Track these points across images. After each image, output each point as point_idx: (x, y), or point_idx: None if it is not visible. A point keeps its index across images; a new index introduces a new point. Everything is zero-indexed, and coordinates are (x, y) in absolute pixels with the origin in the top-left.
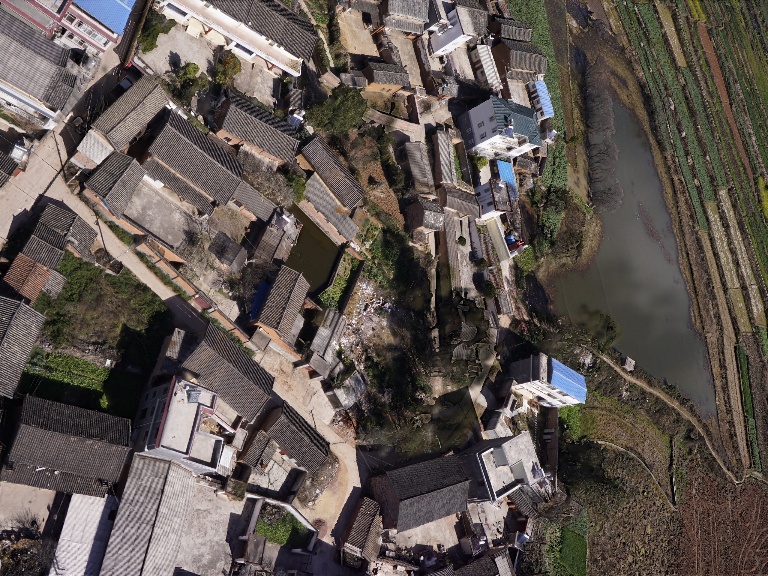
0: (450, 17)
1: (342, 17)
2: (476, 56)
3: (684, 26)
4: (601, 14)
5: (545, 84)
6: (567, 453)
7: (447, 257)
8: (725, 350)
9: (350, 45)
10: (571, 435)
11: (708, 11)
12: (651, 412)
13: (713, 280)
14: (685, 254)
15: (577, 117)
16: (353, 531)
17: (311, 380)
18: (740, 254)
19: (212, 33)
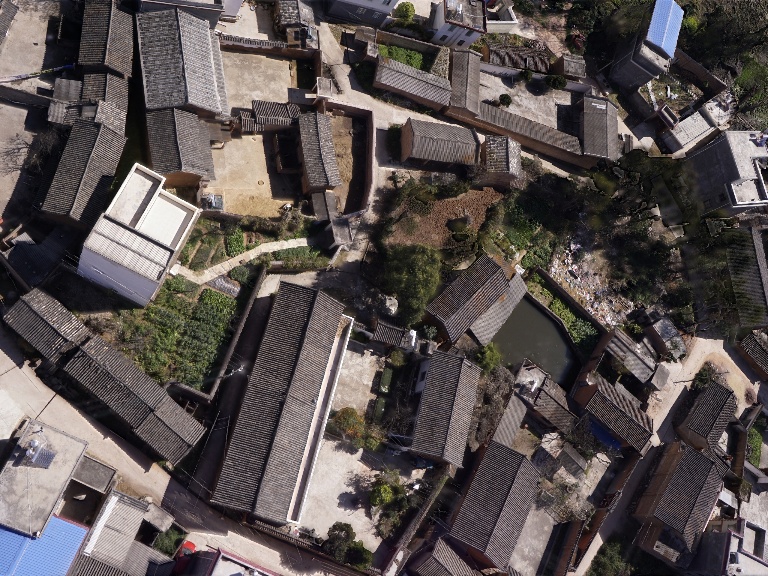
0: None
1: (214, 192)
2: None
3: None
4: None
5: None
6: None
7: (532, 140)
8: None
9: (258, 191)
10: None
11: None
12: None
13: None
14: None
15: None
16: (763, 368)
17: None
18: None
19: None
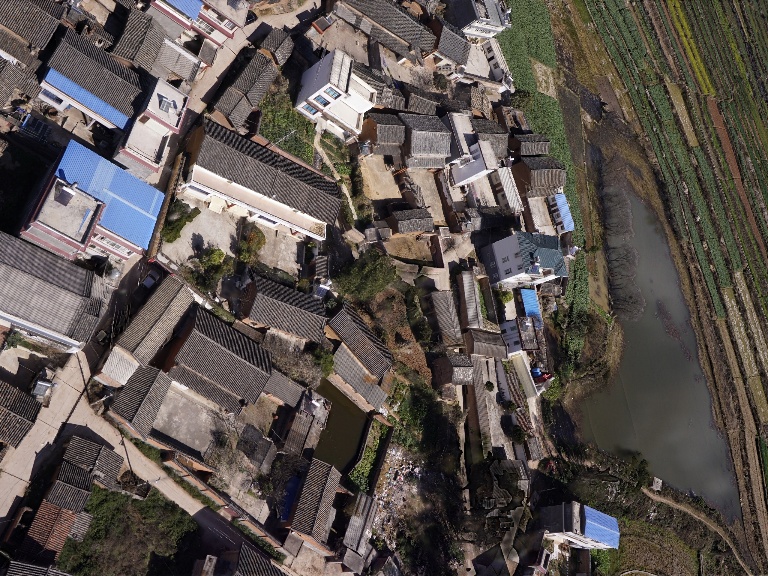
0: (472, 150)
1: (364, 162)
2: (496, 179)
3: (694, 103)
4: (614, 103)
5: (564, 195)
6: None
7: (476, 408)
8: (747, 445)
9: (372, 191)
10: (602, 571)
11: (717, 84)
12: (678, 529)
13: (732, 371)
14: (704, 347)
15: (595, 220)
16: None
17: (344, 573)
18: (757, 338)
19: (235, 206)
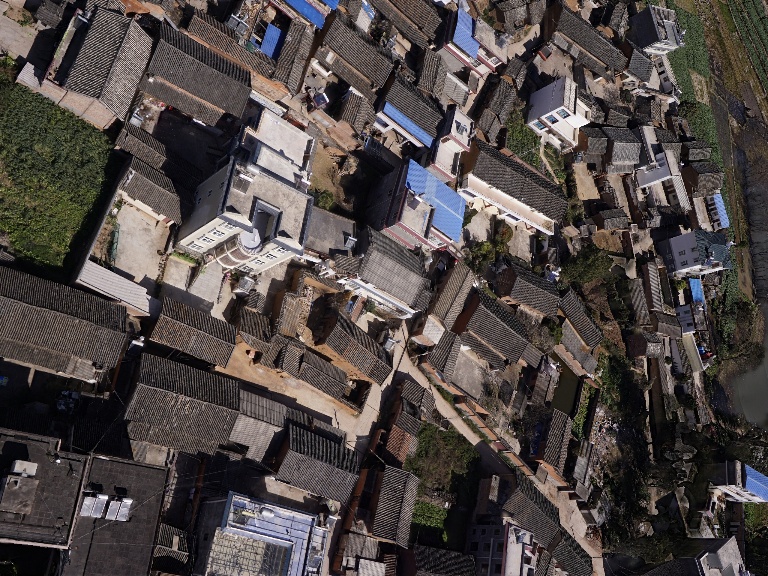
0: (658, 158)
1: (573, 168)
2: (669, 181)
3: None
4: (755, 107)
5: (721, 196)
6: (752, 545)
7: (659, 378)
8: None
9: (580, 193)
10: (748, 523)
11: None
12: None
13: None
14: None
15: (741, 217)
16: None
17: (570, 500)
18: None
19: None
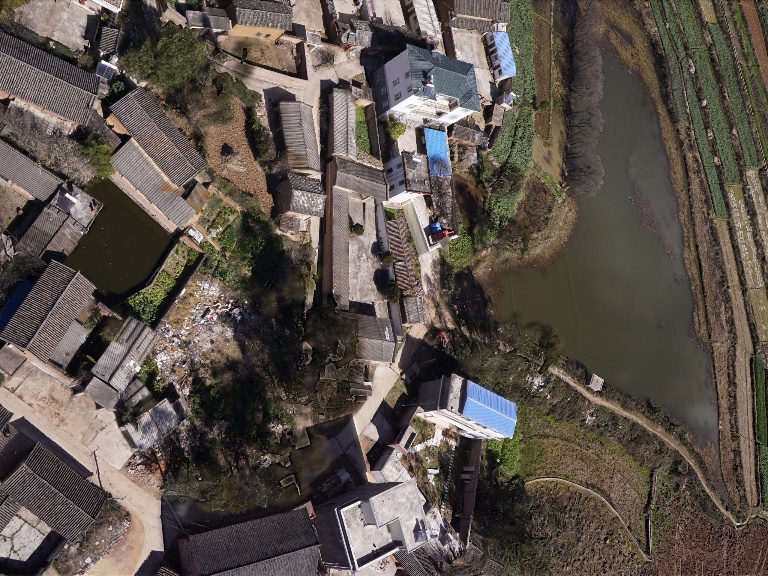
0: None
1: None
2: None
3: None
4: None
5: None
6: (489, 498)
7: (331, 250)
8: (737, 363)
9: None
10: (506, 471)
11: None
12: (625, 440)
13: (729, 278)
14: (693, 247)
15: (557, 78)
16: None
17: (98, 411)
18: (767, 247)
19: None
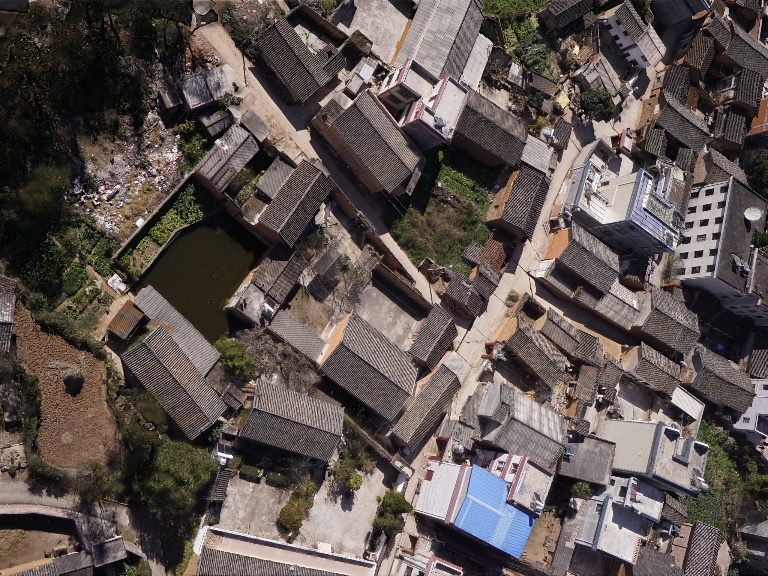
0: None
1: None
2: None
3: None
4: None
5: None
6: None
7: None
8: None
9: None
10: None
11: None
12: None
13: None
14: None
15: None
16: None
17: None
18: None
19: None
